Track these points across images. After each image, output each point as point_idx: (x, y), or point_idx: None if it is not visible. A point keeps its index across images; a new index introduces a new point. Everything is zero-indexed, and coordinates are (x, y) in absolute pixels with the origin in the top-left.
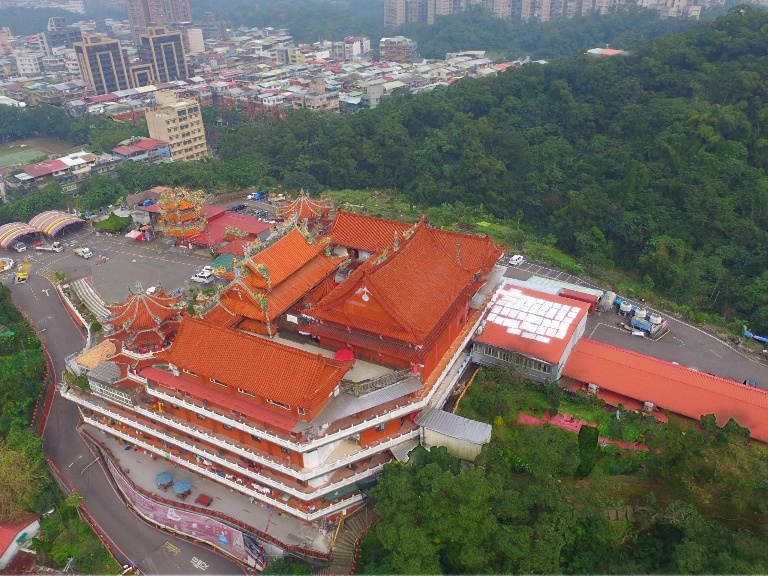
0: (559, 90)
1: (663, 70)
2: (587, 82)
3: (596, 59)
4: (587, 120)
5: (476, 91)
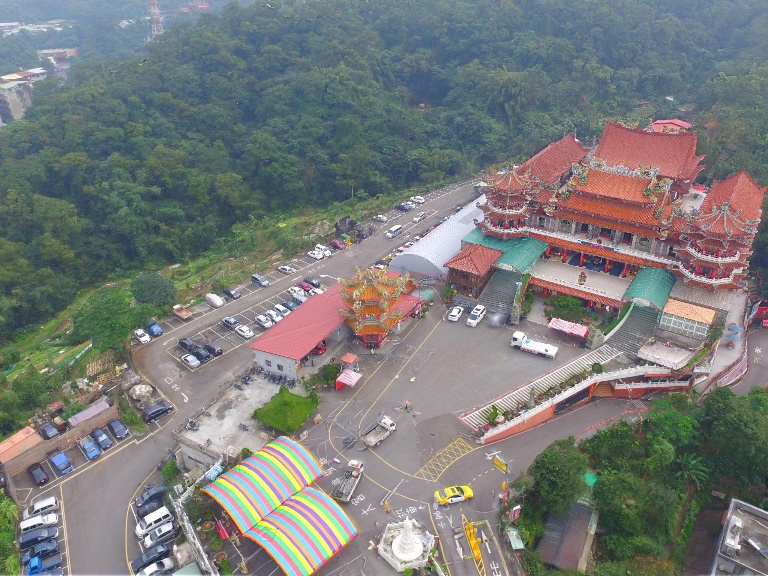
0: (168, 101)
1: (234, 60)
2: (183, 87)
3: (161, 67)
4: (227, 116)
5: (86, 131)
